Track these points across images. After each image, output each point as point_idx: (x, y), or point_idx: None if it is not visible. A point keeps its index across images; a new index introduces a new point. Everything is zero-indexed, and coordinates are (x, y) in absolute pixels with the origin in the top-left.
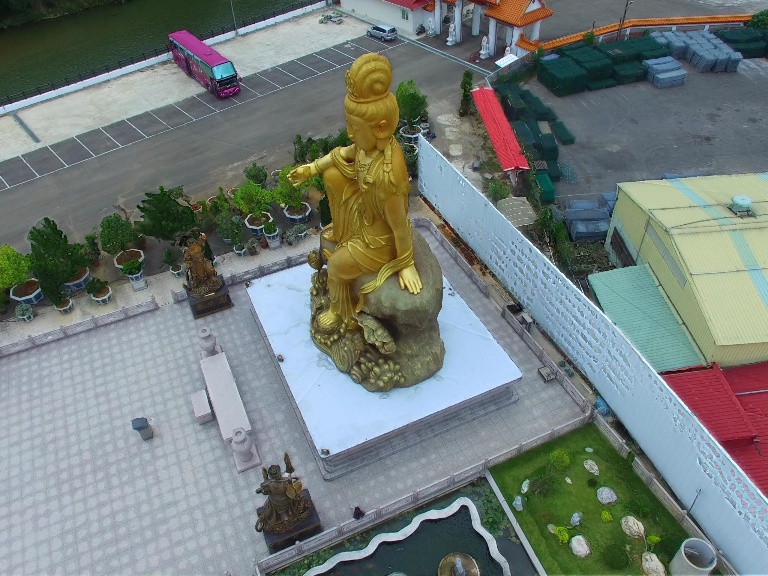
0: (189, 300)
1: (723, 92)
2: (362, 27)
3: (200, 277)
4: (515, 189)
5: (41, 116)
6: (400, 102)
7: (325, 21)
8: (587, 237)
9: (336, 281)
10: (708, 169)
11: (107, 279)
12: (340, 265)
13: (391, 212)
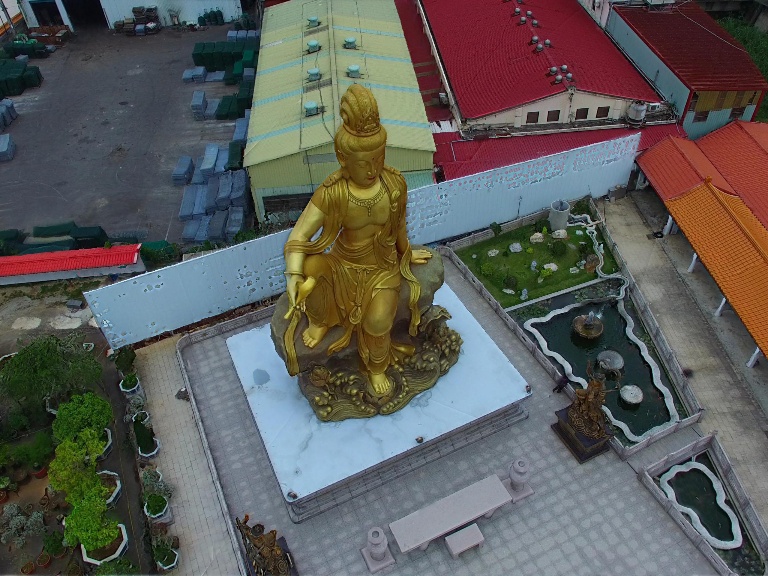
0: None
1: (48, 128)
2: None
3: None
4: None
5: None
6: None
7: None
8: (243, 231)
9: None
10: (165, 158)
11: None
12: None
13: None
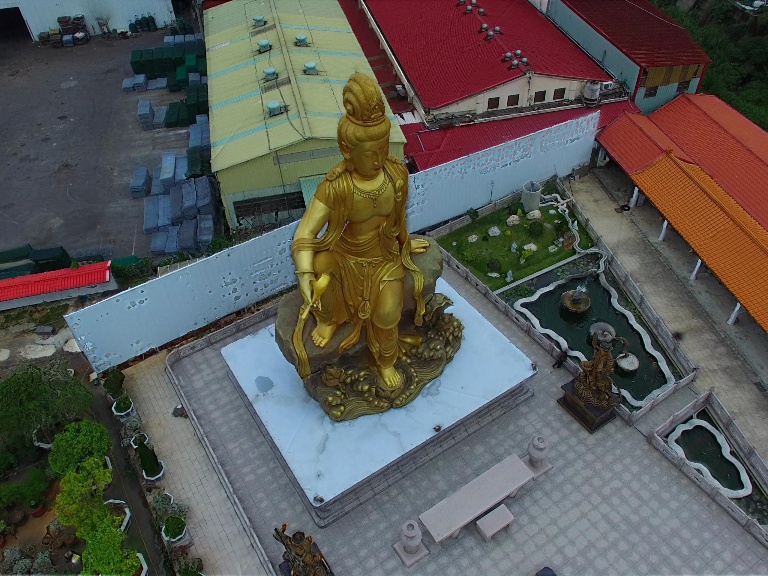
0: None
1: None
2: None
3: None
4: (119, 289)
5: None
6: None
7: None
8: None
9: None
10: (117, 171)
11: None
12: None
13: None
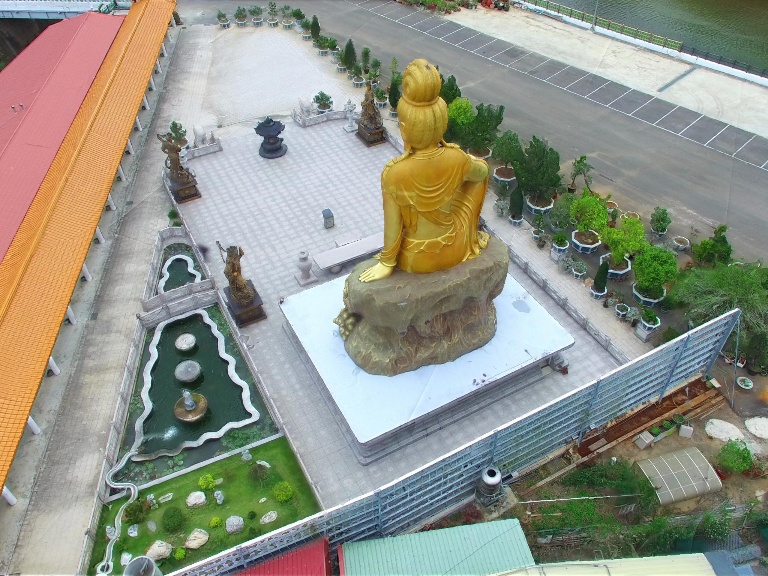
0: None
1: None
2: None
3: None
4: None
5: (702, 80)
6: None
7: None
8: None
9: None
10: None
11: None
12: None
13: None
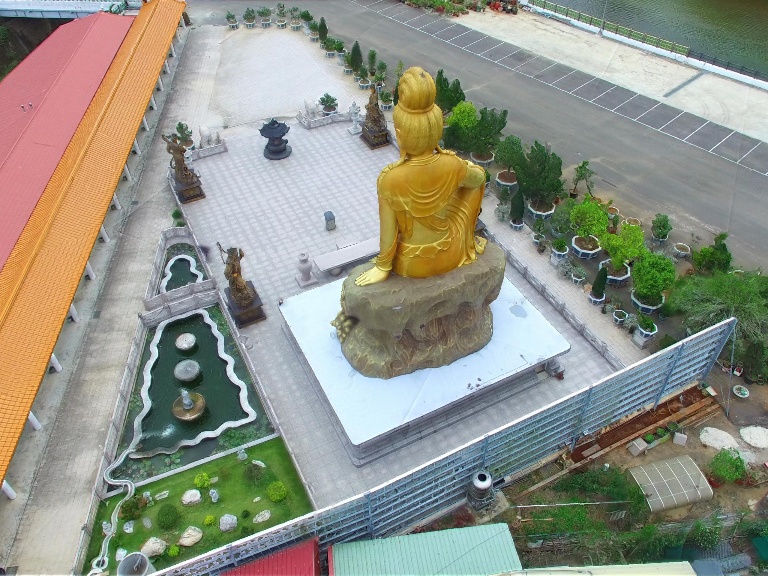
0: None
1: None
2: None
3: None
4: (763, 500)
5: (709, 86)
6: None
7: None
8: None
9: None
10: None
11: None
12: None
13: None
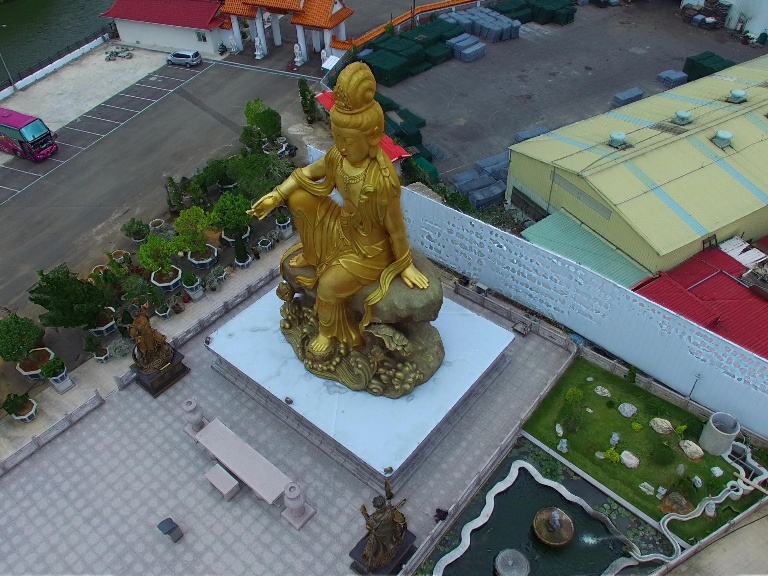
0: (145, 380)
1: (518, 56)
2: (157, 57)
3: (150, 351)
4: (401, 178)
5: None
6: (258, 121)
7: (113, 58)
8: (486, 203)
9: (333, 303)
10: (543, 122)
11: (16, 393)
12: (338, 285)
13: (392, 216)
